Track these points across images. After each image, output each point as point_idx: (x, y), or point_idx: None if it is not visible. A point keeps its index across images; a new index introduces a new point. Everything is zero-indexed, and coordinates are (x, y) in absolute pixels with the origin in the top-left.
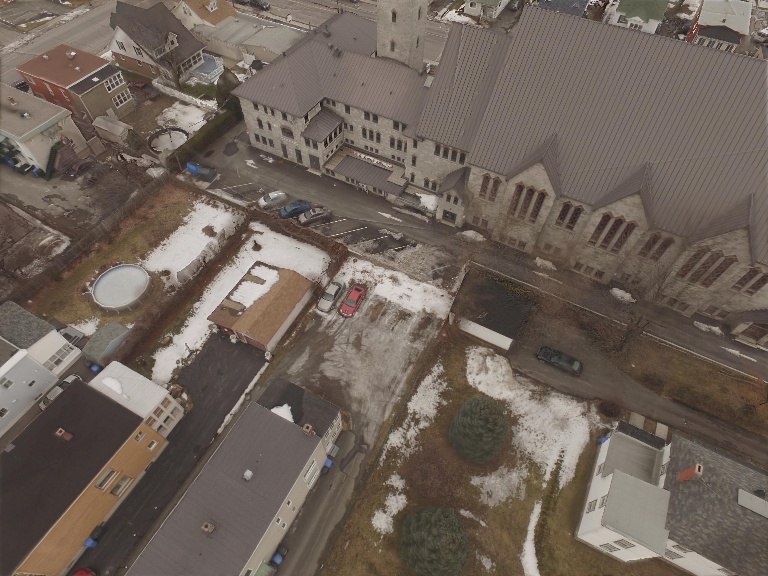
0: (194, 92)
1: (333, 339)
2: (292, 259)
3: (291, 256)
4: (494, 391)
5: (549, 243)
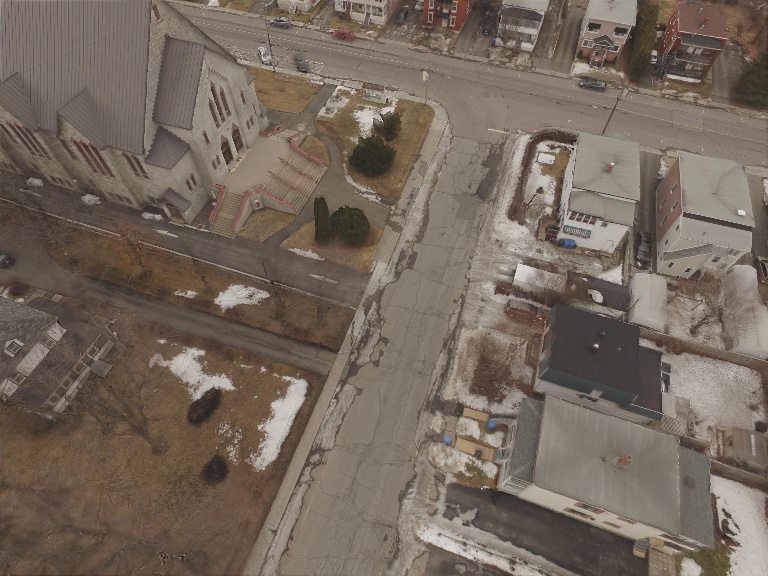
0: None
1: None
2: None
3: None
4: None
5: (31, 162)
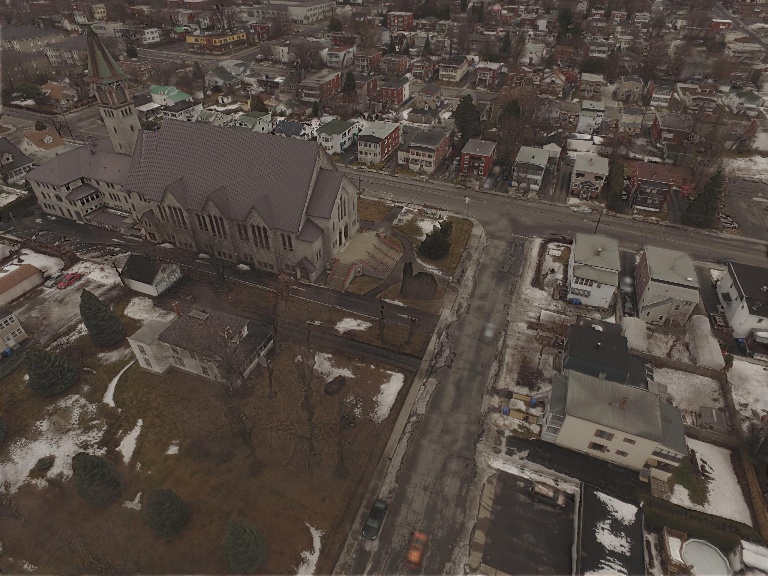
0: (19, 187)
1: (46, 300)
2: (41, 265)
3: (42, 264)
4: (137, 315)
5: (205, 243)
